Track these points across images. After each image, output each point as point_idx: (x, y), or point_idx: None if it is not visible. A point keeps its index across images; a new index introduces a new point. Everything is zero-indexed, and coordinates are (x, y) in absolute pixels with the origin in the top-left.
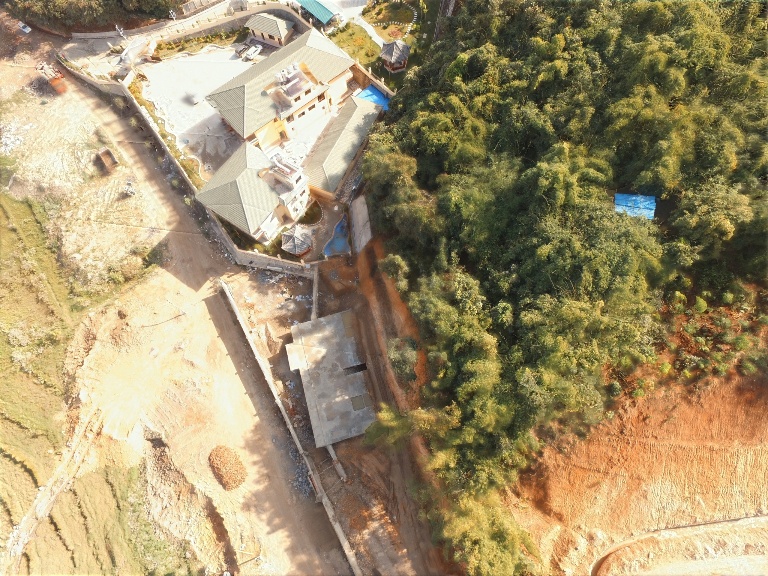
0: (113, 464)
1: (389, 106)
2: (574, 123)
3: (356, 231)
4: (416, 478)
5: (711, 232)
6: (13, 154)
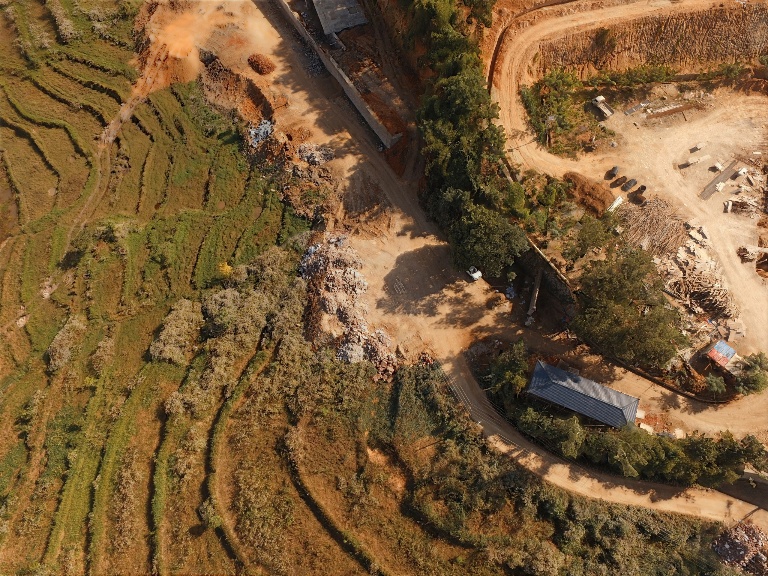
0: (176, 81)
1: None
2: None
3: None
4: (393, 45)
5: None
6: None
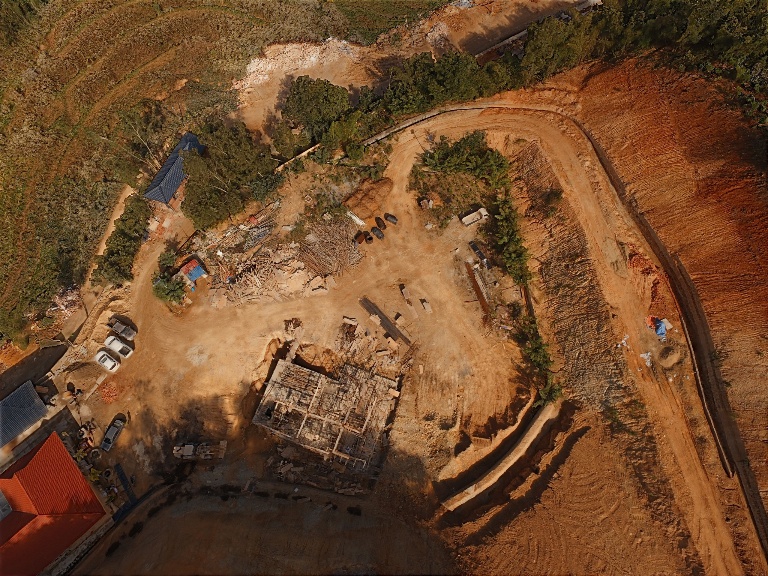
0: None
1: None
2: None
3: None
4: None
5: None
6: None
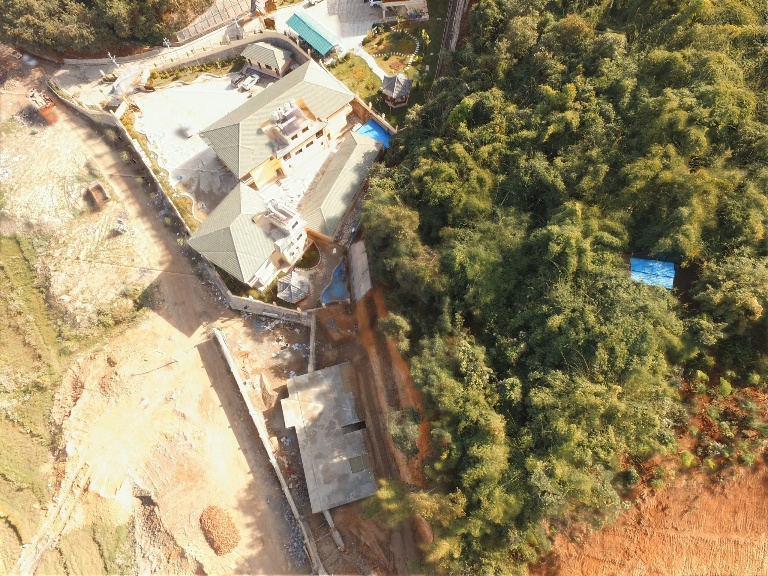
0: (101, 522)
1: (390, 144)
2: (587, 181)
3: (355, 277)
4: (417, 548)
5: (736, 309)
6: (1, 188)
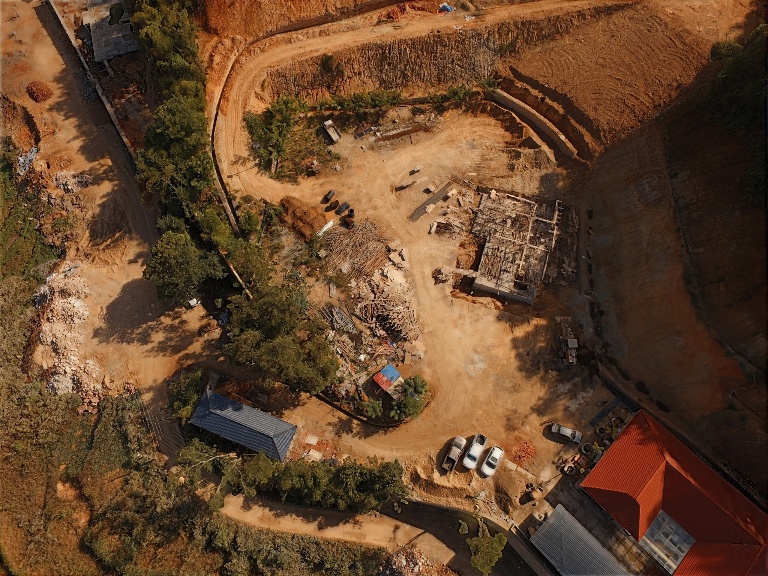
0: None
1: None
2: None
3: None
4: None
5: None
6: None
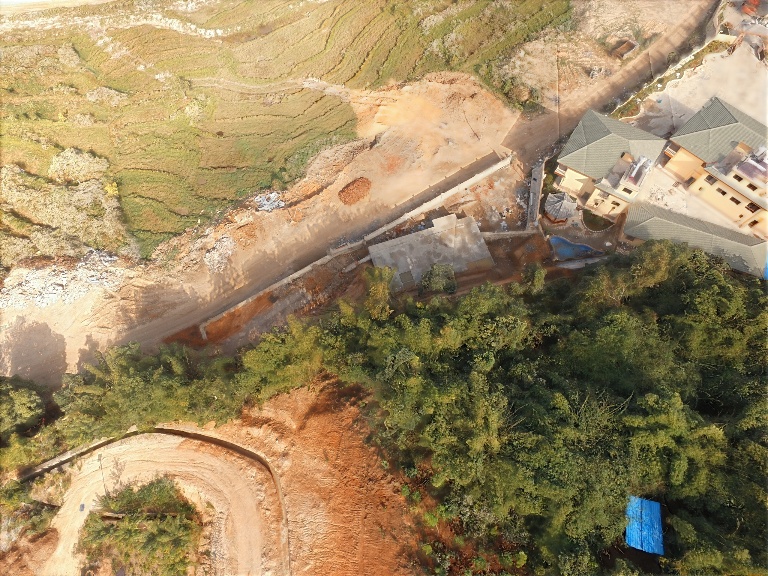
0: (359, 121)
1: (761, 279)
2: (760, 450)
3: None
4: None
5: None
6: None
